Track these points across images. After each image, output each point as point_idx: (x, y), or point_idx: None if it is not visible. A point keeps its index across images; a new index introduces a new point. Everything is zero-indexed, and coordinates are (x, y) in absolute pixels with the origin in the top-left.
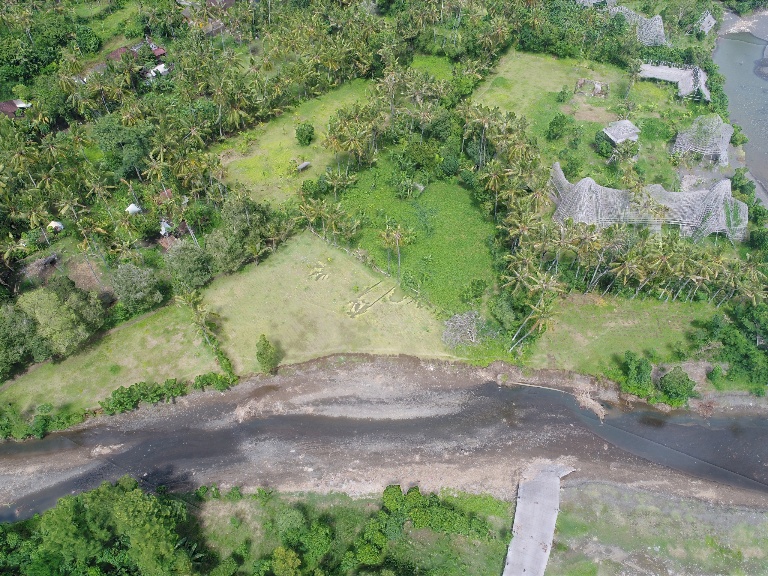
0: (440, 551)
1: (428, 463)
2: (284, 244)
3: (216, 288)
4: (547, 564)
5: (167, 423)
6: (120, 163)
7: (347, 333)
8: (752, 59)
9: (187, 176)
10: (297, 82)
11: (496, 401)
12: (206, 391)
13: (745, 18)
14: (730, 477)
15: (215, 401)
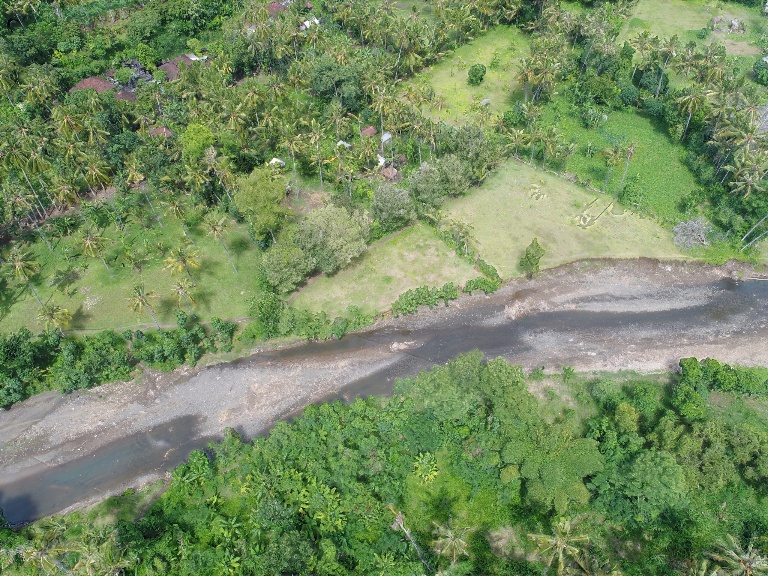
0: (737, 411)
1: (697, 344)
2: (494, 170)
3: (448, 209)
4: None
5: (448, 322)
6: (326, 103)
7: (585, 242)
8: None
9: (396, 111)
10: (458, 27)
11: (737, 293)
12: (473, 295)
13: None
14: None
15: (483, 303)
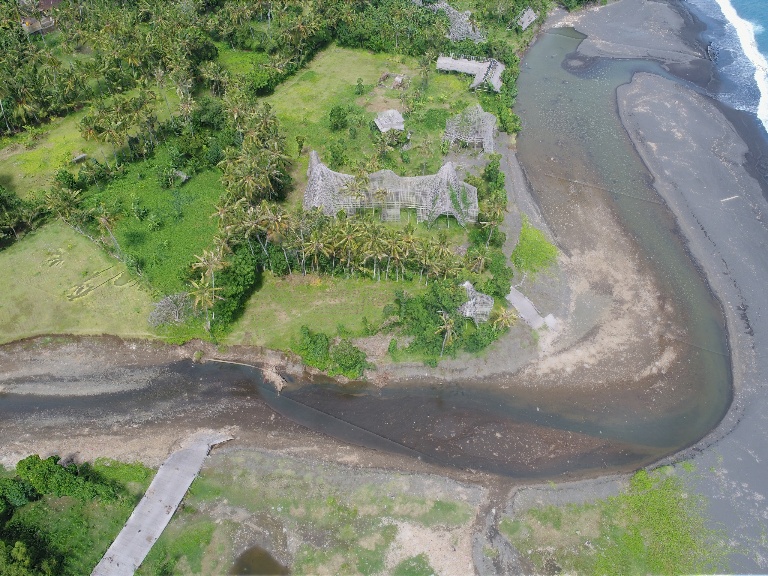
0: (70, 516)
1: (95, 435)
2: (33, 232)
3: None
4: (169, 525)
5: None
6: None
7: (59, 315)
8: (565, 52)
9: None
10: (92, 77)
11: (185, 377)
12: None
13: (573, 13)
14: (379, 442)
15: None
